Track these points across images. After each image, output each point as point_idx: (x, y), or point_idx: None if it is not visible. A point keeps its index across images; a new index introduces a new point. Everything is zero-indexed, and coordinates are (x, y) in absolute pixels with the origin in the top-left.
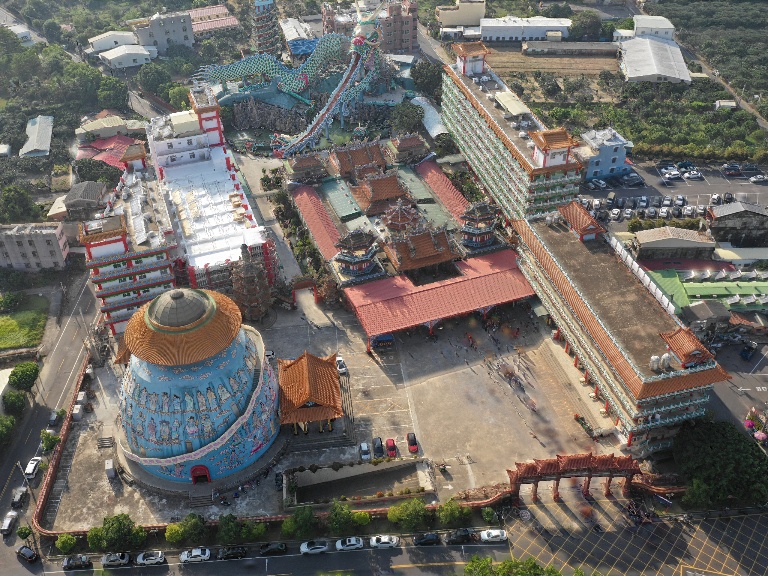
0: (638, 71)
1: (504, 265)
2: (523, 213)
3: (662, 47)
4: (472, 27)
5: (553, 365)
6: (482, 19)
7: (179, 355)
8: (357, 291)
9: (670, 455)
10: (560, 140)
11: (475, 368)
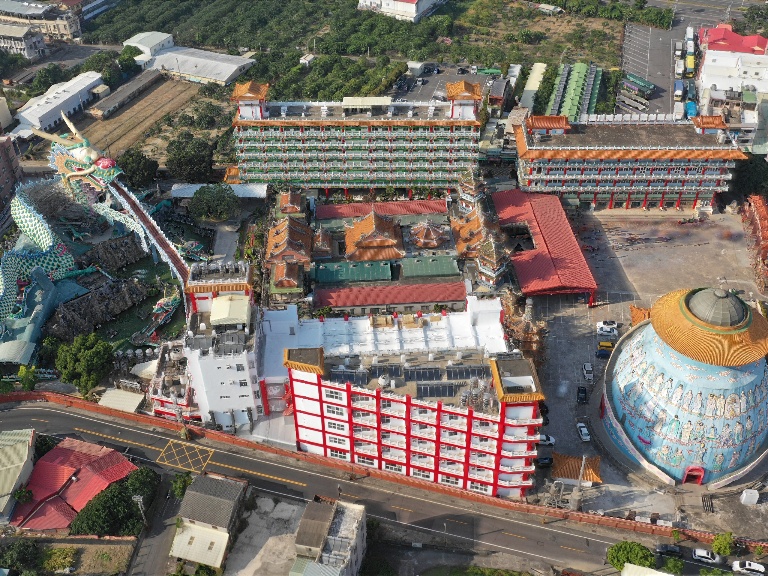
0: (221, 74)
1: (520, 199)
2: (474, 164)
3: (187, 53)
4: (15, 128)
5: (623, 219)
6: (26, 113)
7: (763, 327)
8: (531, 284)
9: (719, 196)
10: (472, 88)
11: (619, 255)
